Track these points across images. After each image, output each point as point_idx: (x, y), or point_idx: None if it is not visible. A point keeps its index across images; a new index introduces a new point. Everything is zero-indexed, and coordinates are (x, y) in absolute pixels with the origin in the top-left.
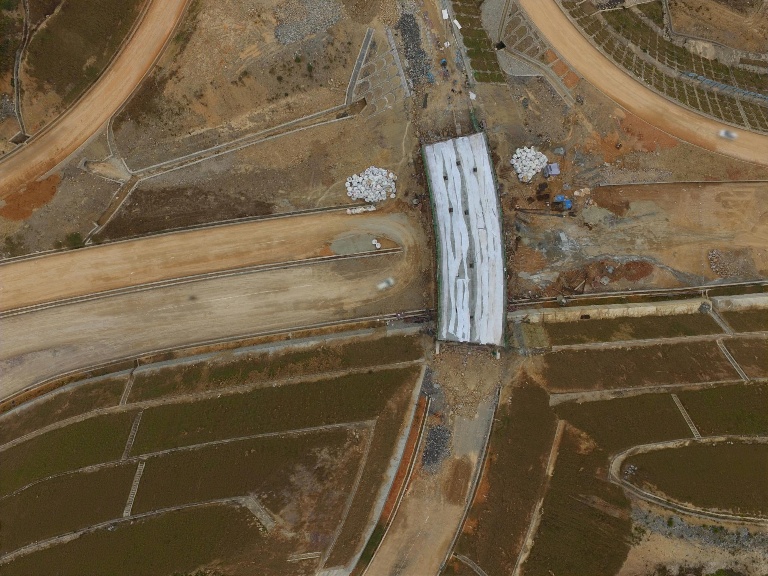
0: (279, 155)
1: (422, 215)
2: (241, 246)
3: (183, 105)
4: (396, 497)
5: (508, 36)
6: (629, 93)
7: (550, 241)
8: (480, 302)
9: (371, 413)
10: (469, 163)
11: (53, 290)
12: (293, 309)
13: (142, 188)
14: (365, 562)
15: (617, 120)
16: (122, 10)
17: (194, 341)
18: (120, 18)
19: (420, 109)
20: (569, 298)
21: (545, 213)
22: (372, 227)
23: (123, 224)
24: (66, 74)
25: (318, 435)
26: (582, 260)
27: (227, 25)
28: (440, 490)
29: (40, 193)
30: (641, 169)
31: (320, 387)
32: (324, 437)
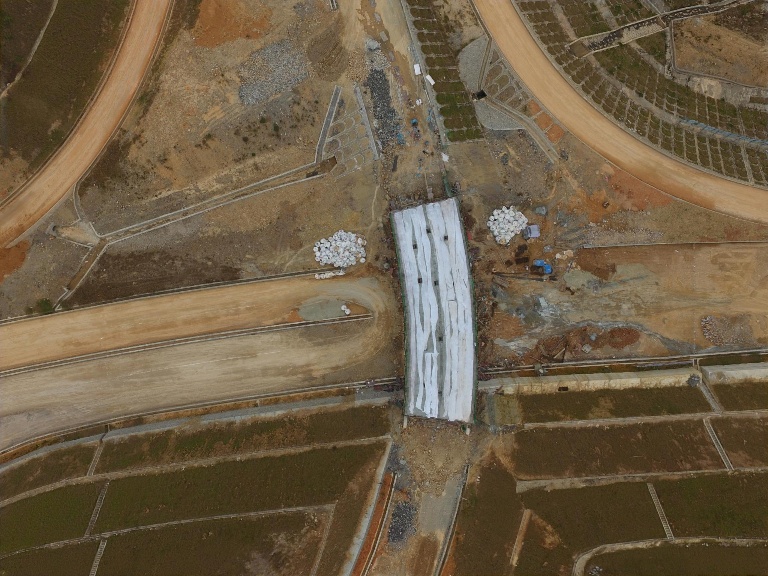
0: (247, 217)
1: (393, 280)
2: (209, 312)
3: (148, 169)
4: (361, 572)
5: (489, 85)
6: (619, 146)
7: (529, 306)
8: (449, 377)
9: (330, 497)
10: (440, 231)
11: (26, 355)
12: (261, 375)
13: (110, 252)
14: None
15: (605, 177)
16: (85, 71)
17: (163, 406)
18: (84, 79)
19: (389, 173)
20: (548, 366)
21: (524, 277)
22: (341, 292)
23: (91, 290)
24: (31, 140)
25: (276, 519)
26: (563, 326)
27: (190, 86)
28: (405, 567)
29: (9, 260)
30: (630, 229)
31: (283, 463)
32: (282, 521)
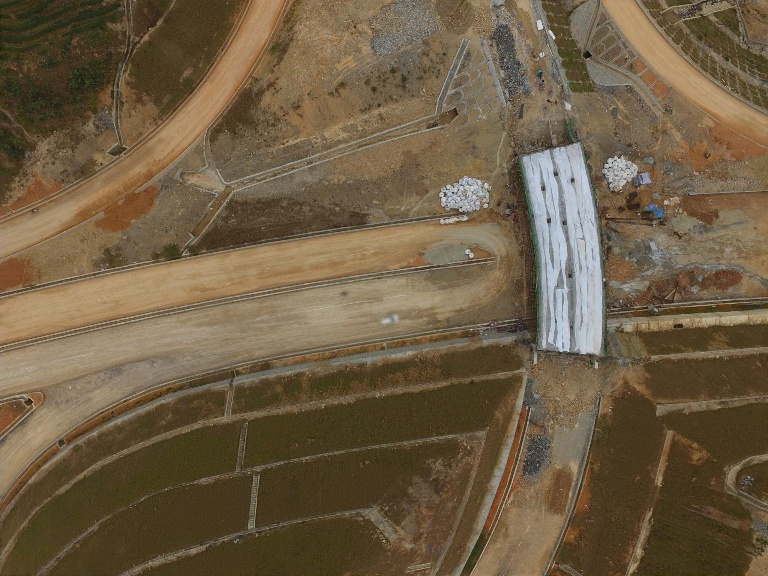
0: (371, 165)
1: (514, 225)
2: (336, 256)
3: (279, 116)
4: (497, 507)
5: (595, 45)
6: (717, 102)
7: (640, 250)
8: (579, 312)
9: (481, 424)
10: (566, 173)
11: (150, 301)
12: (387, 319)
13: (237, 199)
14: (467, 572)
15: (706, 129)
16: (218, 22)
17: (290, 351)
18: (216, 29)
19: (516, 120)
20: (660, 307)
21: (635, 222)
22: (465, 237)
23: (220, 235)
24: (164, 86)
25: (430, 446)
26: (672, 269)
27: (323, 36)
28: (541, 500)
29: (139, 204)
30: (730, 178)
31: (424, 398)
32: (437, 448)
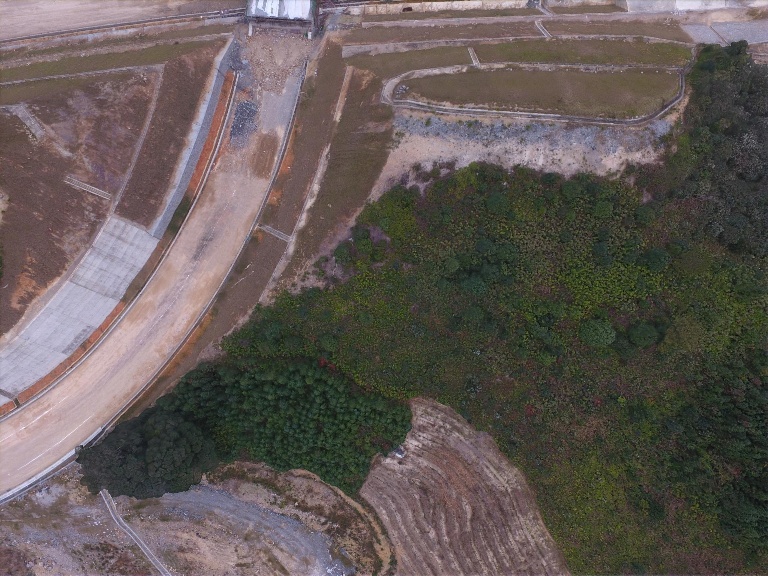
0: None
1: None
2: None
3: None
4: (203, 170)
5: None
6: None
7: None
8: None
9: None
10: None
11: None
12: (118, 6)
13: None
14: (172, 233)
15: None
16: None
17: (21, 36)
18: None
19: None
20: None
21: None
22: None
23: None
24: None
25: (106, 76)
26: None
27: None
28: (246, 163)
29: None
30: None
31: (125, 54)
32: (110, 76)
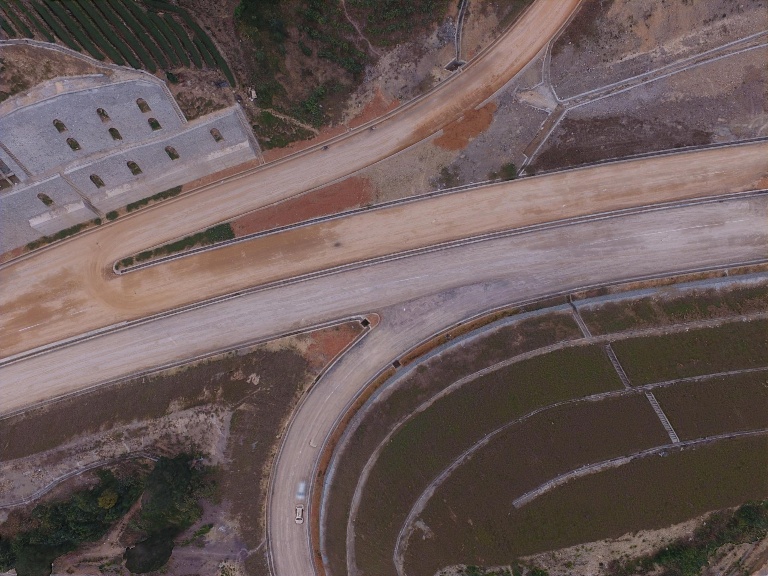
0: (711, 82)
1: None
2: (676, 178)
3: (625, 27)
4: None
5: None
6: None
7: None
8: None
9: None
10: None
11: (485, 223)
12: (728, 245)
13: (571, 117)
14: None
15: None
16: None
17: (625, 277)
18: None
19: None
20: None
21: None
22: None
23: (559, 154)
24: None
25: None
26: None
27: None
28: None
29: (480, 121)
30: None
31: None
32: None
